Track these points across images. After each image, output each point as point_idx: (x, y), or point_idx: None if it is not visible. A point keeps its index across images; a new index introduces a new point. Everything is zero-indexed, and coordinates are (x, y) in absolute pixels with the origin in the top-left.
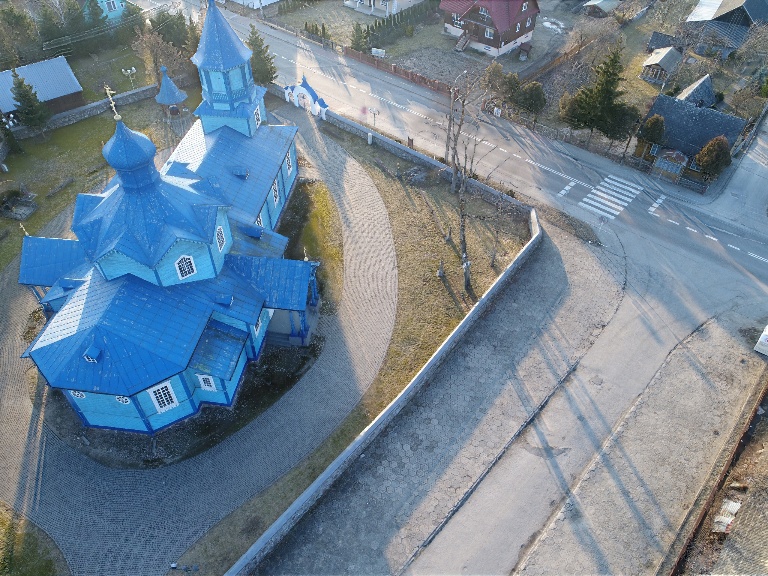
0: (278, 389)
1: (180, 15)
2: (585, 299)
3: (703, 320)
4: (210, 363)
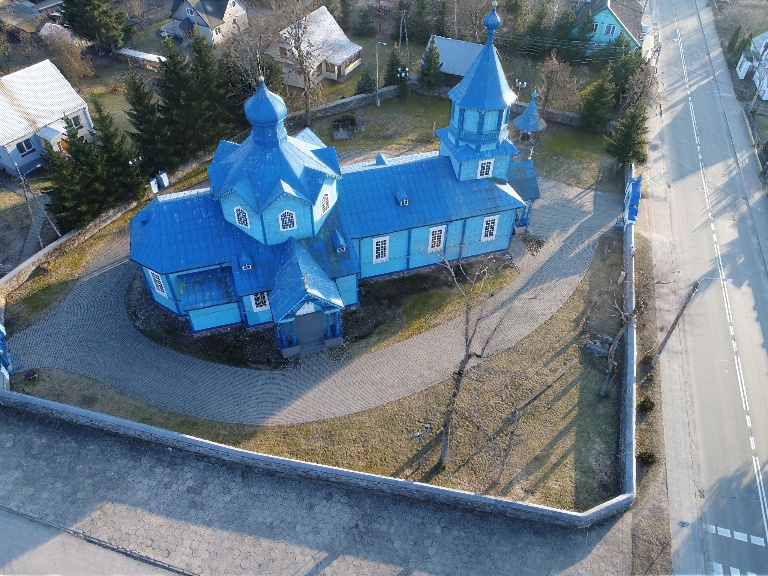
0: (227, 358)
1: (645, 64)
2: None
3: None
4: (190, 290)
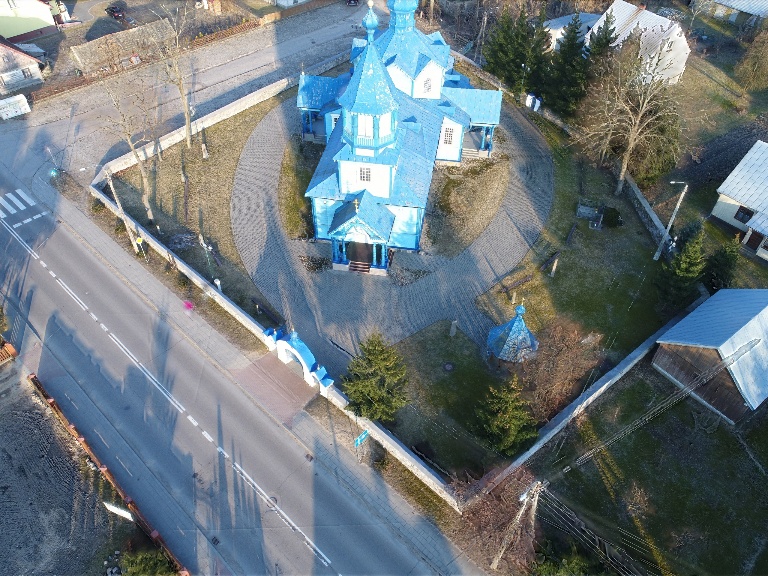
0: None
1: None
2: (110, 137)
3: (41, 126)
4: None
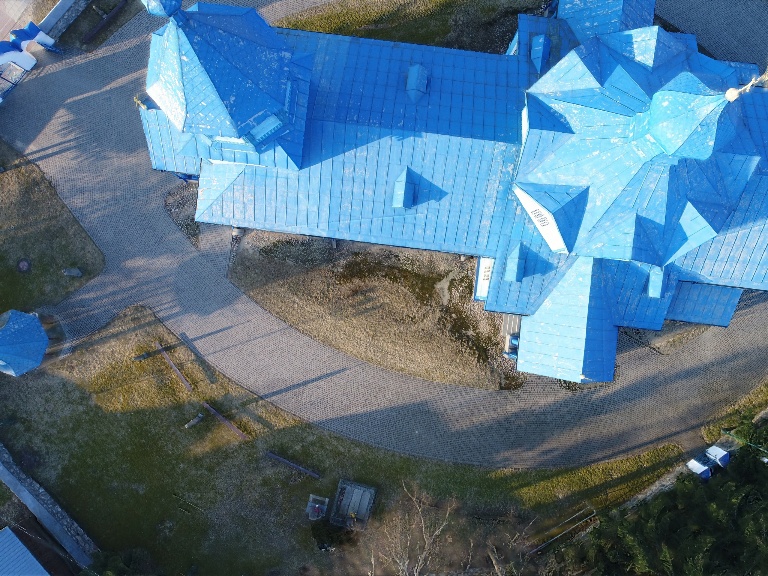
0: None
1: None
2: None
3: None
4: None
